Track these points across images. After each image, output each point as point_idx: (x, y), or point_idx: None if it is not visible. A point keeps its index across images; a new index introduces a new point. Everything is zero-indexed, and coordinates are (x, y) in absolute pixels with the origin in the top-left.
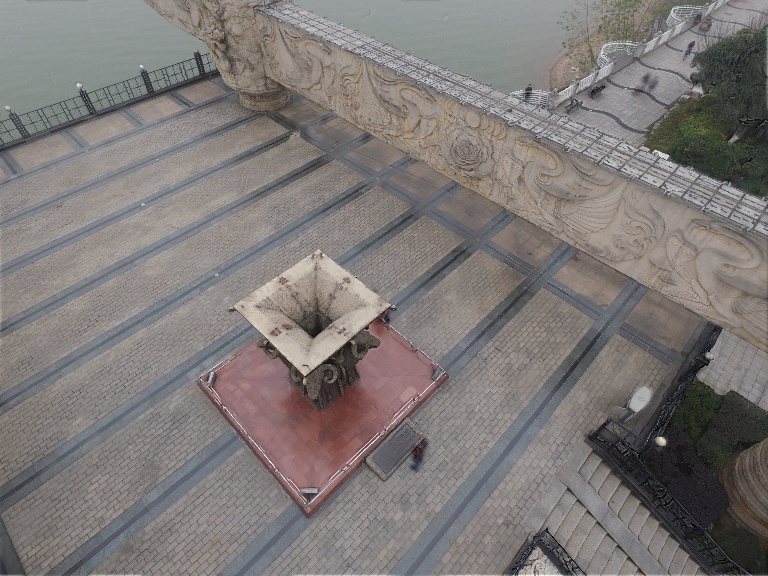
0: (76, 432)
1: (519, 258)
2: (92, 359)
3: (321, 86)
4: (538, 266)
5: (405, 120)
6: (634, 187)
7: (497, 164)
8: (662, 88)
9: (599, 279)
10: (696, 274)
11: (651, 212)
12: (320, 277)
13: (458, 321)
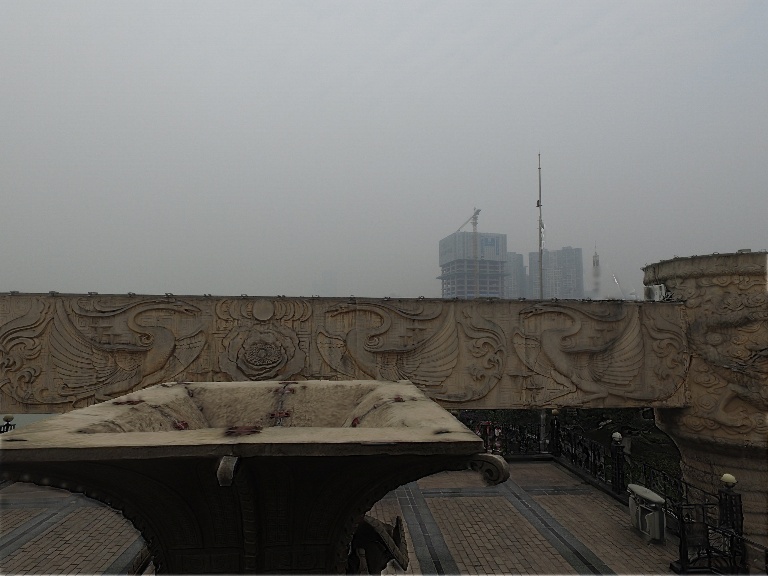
0: None
1: None
2: None
3: None
4: None
5: (147, 355)
6: (461, 307)
7: (308, 354)
8: None
9: (455, 474)
10: (551, 362)
11: (487, 323)
12: (216, 401)
13: (390, 570)
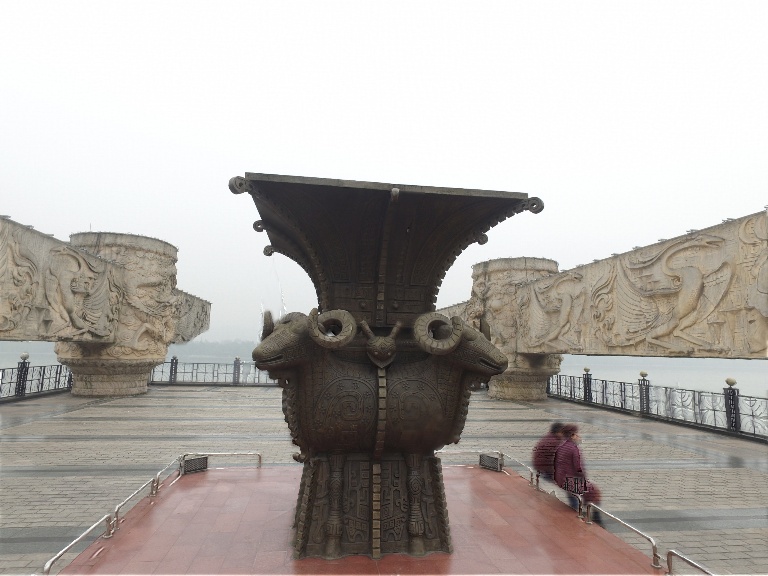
0: (3, 465)
1: None
2: (130, 441)
3: (570, 325)
4: None
5: (678, 297)
6: None
7: None
8: None
9: None
10: None
11: None
12: None
13: None
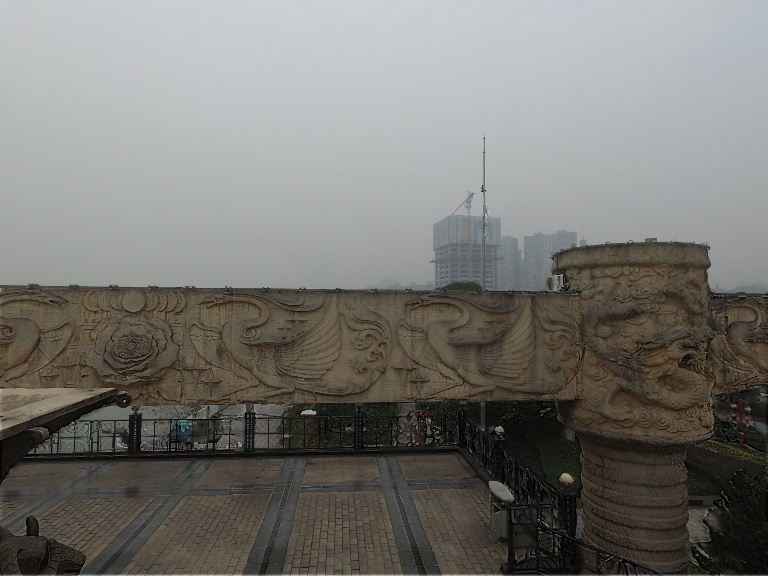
0: None
1: (248, 484)
2: None
3: None
4: (277, 481)
5: (8, 348)
6: (345, 298)
7: (182, 347)
8: (268, 409)
9: (349, 466)
10: (437, 355)
11: (371, 314)
12: None
13: (211, 572)
